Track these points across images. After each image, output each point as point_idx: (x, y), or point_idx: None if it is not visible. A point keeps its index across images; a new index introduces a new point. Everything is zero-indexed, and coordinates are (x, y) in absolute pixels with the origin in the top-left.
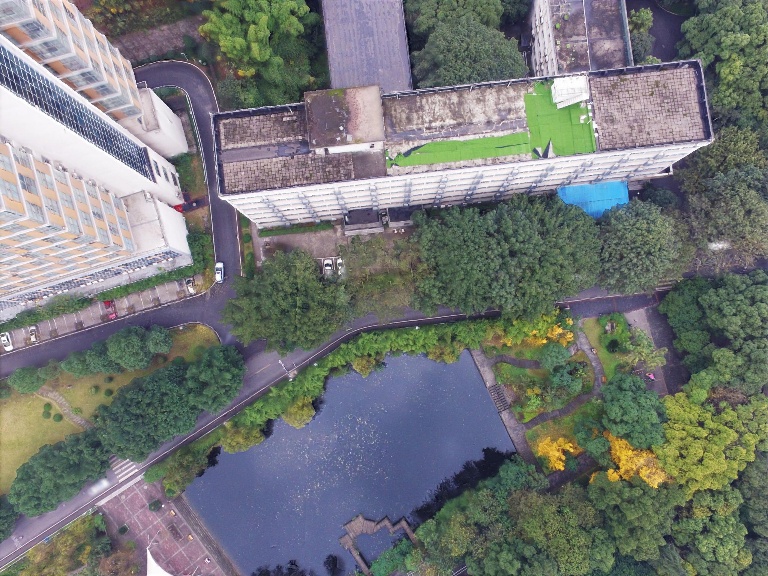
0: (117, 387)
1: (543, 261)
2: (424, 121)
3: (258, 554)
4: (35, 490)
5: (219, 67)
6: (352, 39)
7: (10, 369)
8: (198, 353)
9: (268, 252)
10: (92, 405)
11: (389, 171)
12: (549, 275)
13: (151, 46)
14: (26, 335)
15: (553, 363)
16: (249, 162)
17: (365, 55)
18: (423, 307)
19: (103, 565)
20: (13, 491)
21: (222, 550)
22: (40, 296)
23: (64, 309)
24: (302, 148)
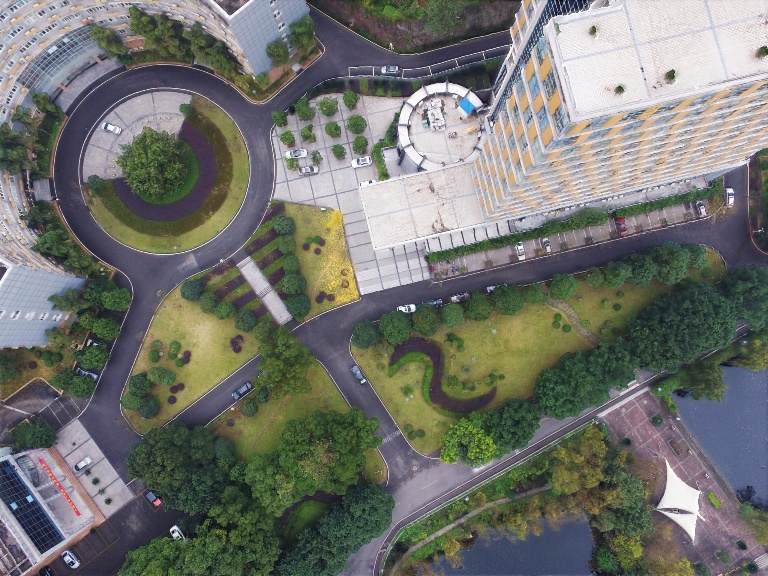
0: (624, 302)
1: None
2: None
3: (748, 474)
4: (570, 393)
5: None
6: None
7: (521, 278)
8: (708, 274)
9: None
10: (599, 318)
11: None
12: None
13: None
14: (537, 246)
15: None
16: None
17: None
18: None
19: (646, 468)
20: (552, 393)
21: (715, 467)
22: (564, 208)
23: (589, 221)
24: None
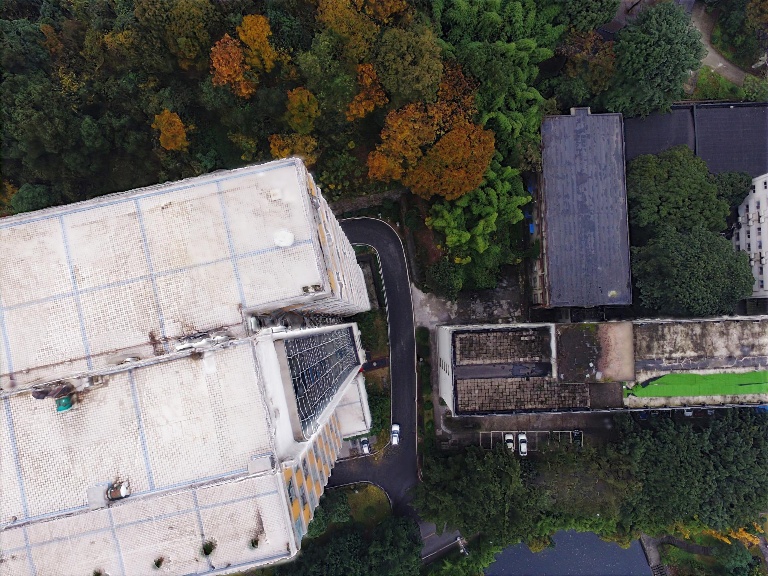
0: None
1: (759, 489)
2: (664, 351)
3: None
4: None
5: (419, 235)
6: (572, 232)
7: None
8: (369, 515)
9: (449, 421)
10: None
11: (625, 401)
12: (763, 503)
13: (349, 206)
14: None
15: (735, 565)
16: (483, 380)
17: (585, 251)
18: (622, 513)
19: None
20: None
21: None
22: None
23: None
24: (537, 369)
